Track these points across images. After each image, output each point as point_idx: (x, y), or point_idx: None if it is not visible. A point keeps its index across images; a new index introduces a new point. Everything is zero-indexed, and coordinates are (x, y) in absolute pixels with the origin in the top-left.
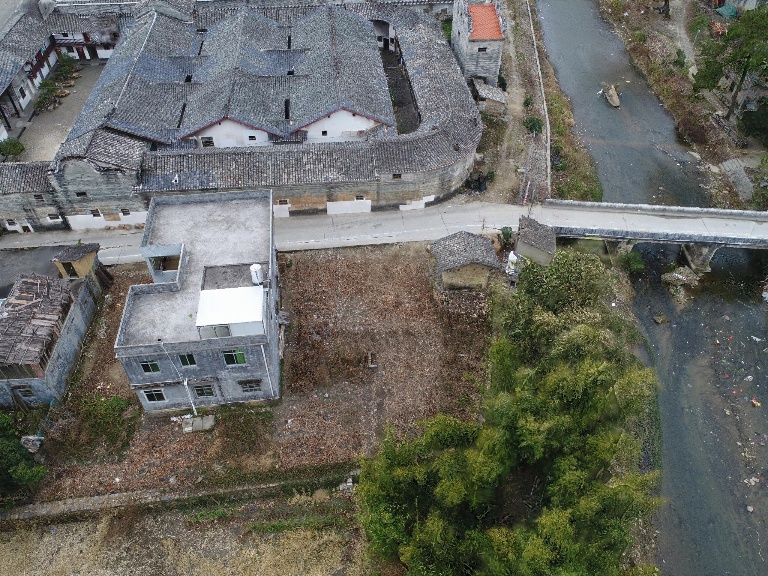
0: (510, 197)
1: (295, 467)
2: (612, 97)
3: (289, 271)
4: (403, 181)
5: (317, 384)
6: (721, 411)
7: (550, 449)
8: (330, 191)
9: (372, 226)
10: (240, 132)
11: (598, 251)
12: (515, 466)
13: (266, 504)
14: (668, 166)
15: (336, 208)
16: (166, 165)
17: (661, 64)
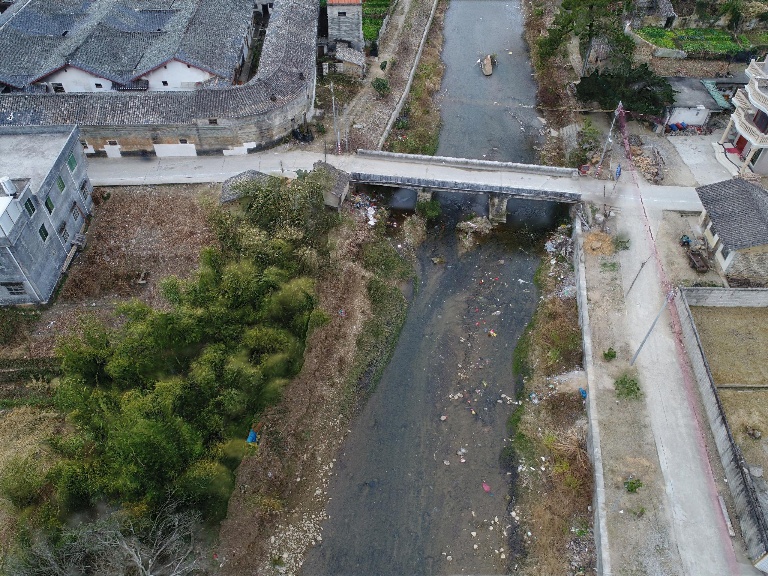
0: (332, 148)
1: (40, 358)
2: (485, 66)
3: (105, 203)
4: (220, 127)
5: (88, 295)
6: (457, 339)
7: (202, 335)
8: (154, 134)
9: (193, 168)
10: (86, 79)
11: (408, 200)
12: (168, 347)
13: (7, 387)
14: (512, 129)
15: (164, 151)
16: (4, 104)
17: (546, 37)
